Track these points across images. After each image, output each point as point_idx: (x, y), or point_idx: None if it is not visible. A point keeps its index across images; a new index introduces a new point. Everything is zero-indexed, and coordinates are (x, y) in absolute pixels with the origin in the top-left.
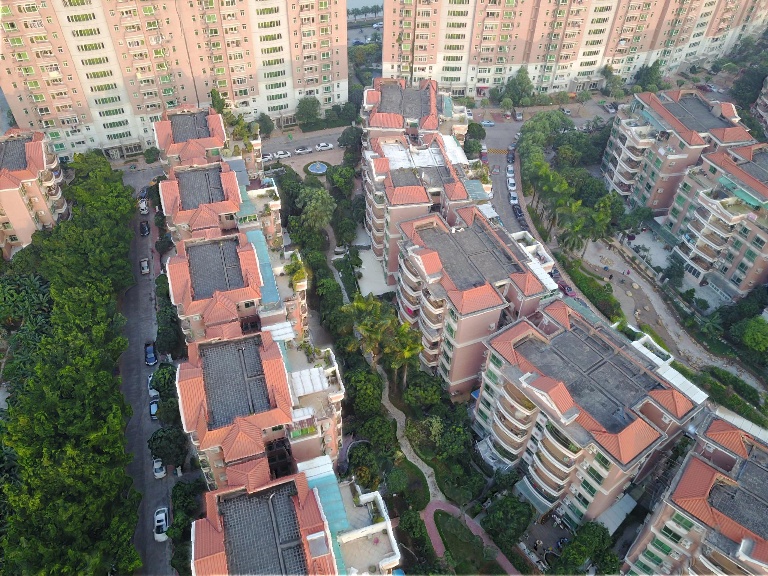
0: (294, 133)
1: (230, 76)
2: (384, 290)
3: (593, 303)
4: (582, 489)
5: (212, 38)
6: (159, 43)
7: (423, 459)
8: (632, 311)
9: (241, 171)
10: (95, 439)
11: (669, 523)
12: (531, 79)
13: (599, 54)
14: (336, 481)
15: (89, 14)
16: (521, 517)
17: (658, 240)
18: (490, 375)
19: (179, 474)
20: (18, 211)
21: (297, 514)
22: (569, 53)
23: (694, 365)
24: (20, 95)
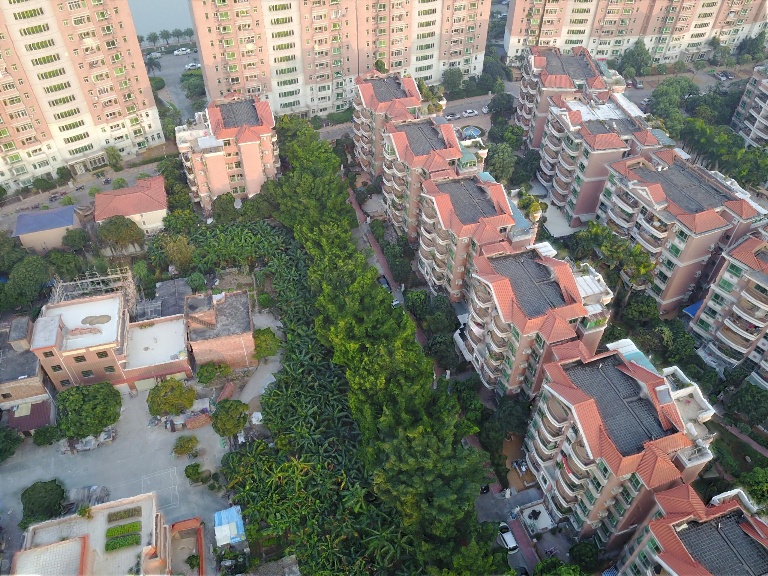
0: None
1: (389, 48)
2: (569, 231)
3: None
4: None
5: (381, 12)
6: (337, 17)
7: None
8: None
9: None
10: (404, 338)
11: None
12: None
13: (709, 26)
14: None
15: None
16: (767, 399)
17: None
18: (723, 285)
19: (447, 377)
20: (254, 163)
21: (633, 376)
22: (683, 25)
23: None
24: (217, 66)
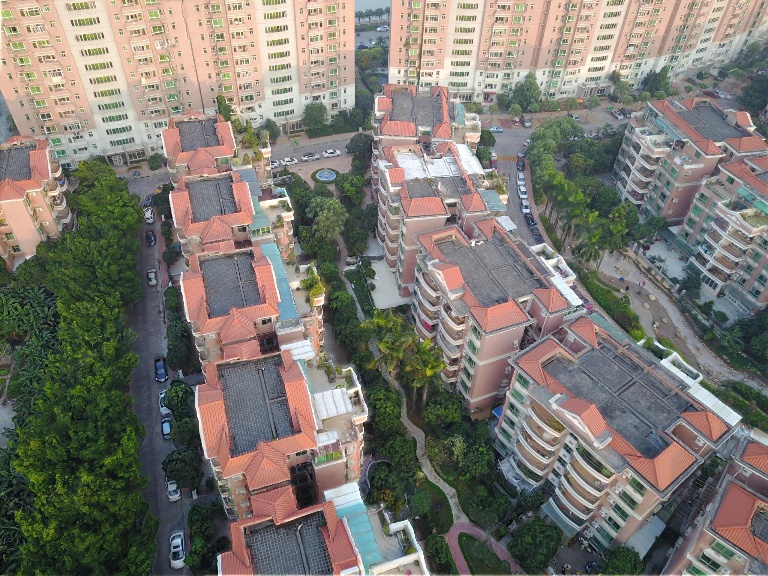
0: (300, 139)
1: (236, 81)
2: (398, 302)
3: (610, 315)
4: (613, 513)
5: (218, 43)
6: (164, 48)
7: (445, 479)
8: (650, 324)
9: (252, 181)
10: (110, 464)
11: (707, 551)
12: (539, 85)
13: (607, 60)
14: (365, 510)
15: (93, 18)
16: (550, 542)
17: (673, 250)
18: (515, 394)
19: (194, 497)
20: (22, 222)
21: (328, 547)
22: (577, 59)
23: (715, 380)
24: (22, 101)
